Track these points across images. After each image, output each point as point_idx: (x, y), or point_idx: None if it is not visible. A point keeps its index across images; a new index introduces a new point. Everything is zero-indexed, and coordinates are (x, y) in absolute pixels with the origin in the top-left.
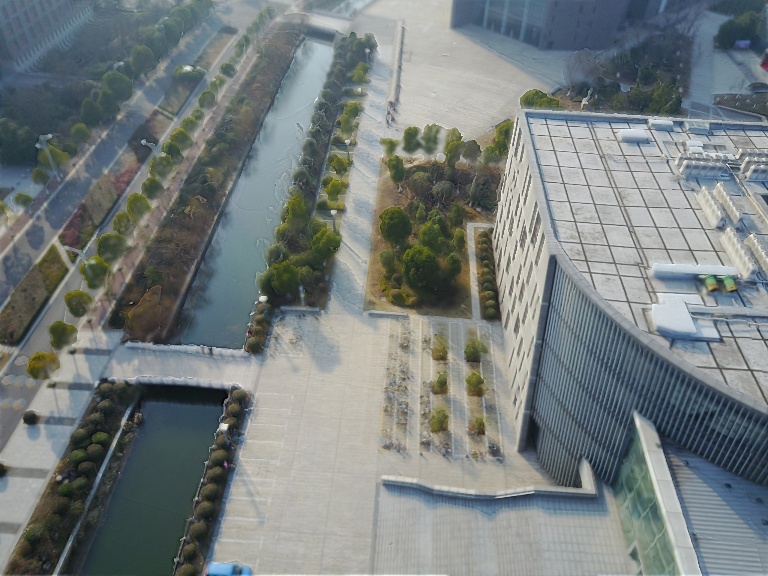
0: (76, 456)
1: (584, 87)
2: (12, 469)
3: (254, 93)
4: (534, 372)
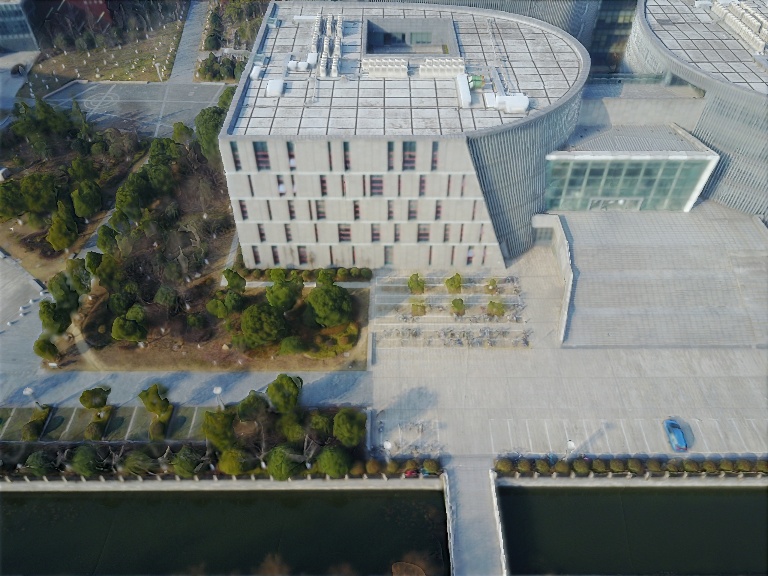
0: None
1: None
2: None
3: None
4: (490, 216)
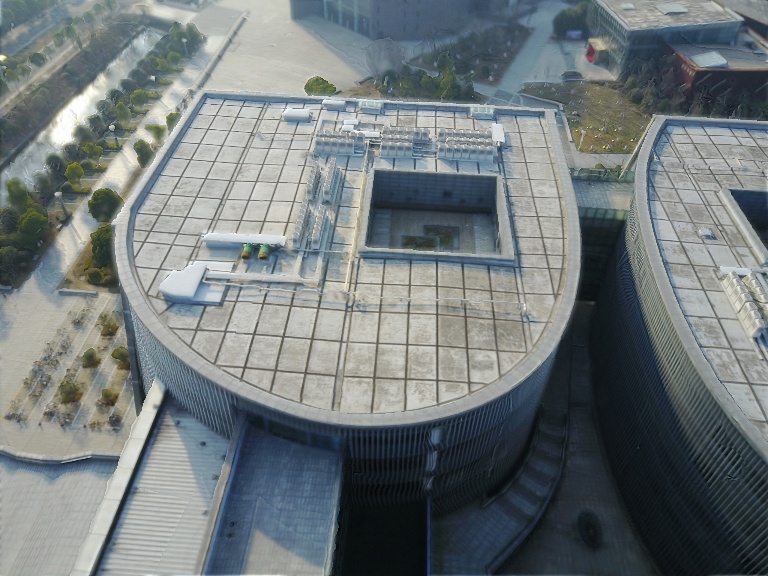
0: None
1: (387, 75)
2: None
3: (60, 82)
4: (130, 342)
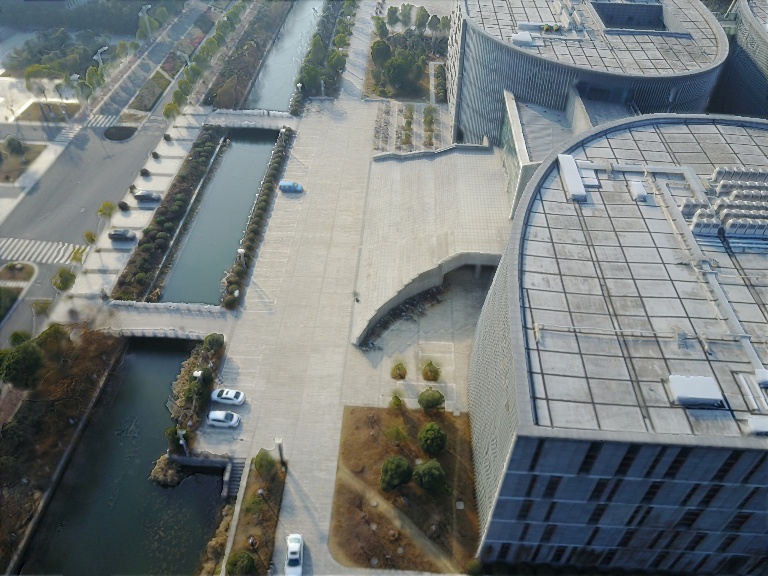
0: (198, 150)
1: None
2: (162, 156)
3: None
4: (458, 96)
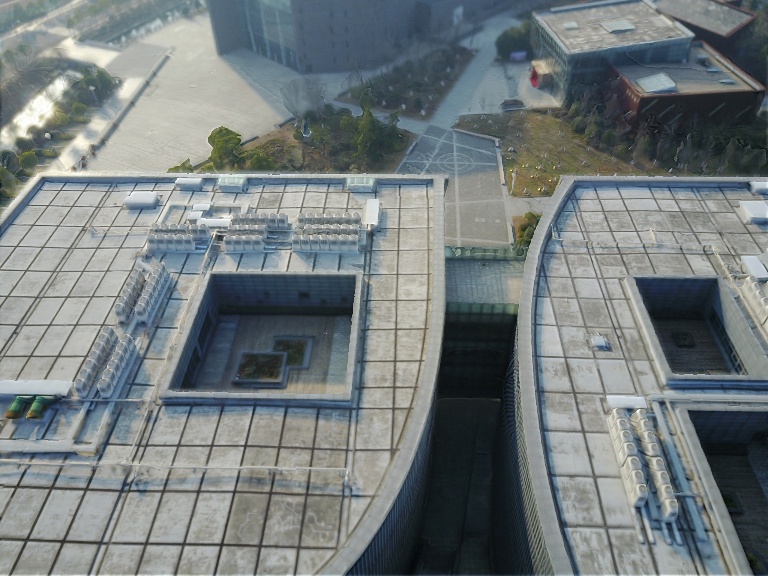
0: None
1: (307, 117)
2: None
3: None
4: None
